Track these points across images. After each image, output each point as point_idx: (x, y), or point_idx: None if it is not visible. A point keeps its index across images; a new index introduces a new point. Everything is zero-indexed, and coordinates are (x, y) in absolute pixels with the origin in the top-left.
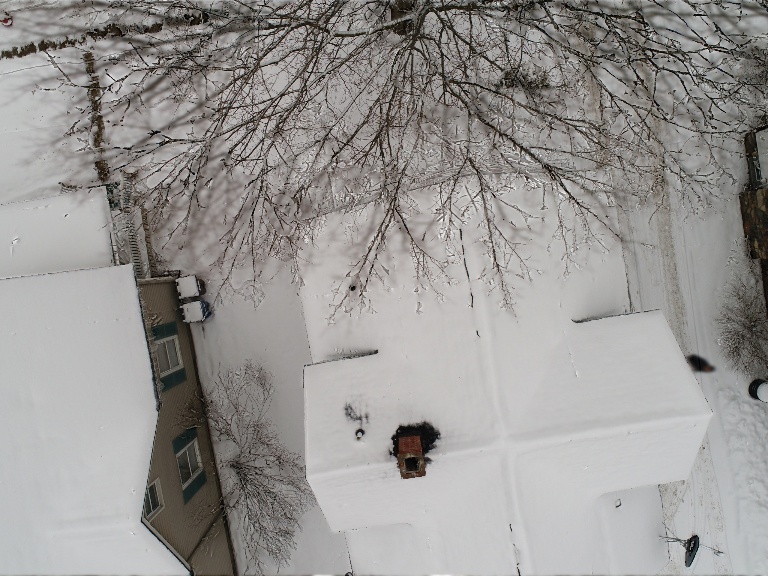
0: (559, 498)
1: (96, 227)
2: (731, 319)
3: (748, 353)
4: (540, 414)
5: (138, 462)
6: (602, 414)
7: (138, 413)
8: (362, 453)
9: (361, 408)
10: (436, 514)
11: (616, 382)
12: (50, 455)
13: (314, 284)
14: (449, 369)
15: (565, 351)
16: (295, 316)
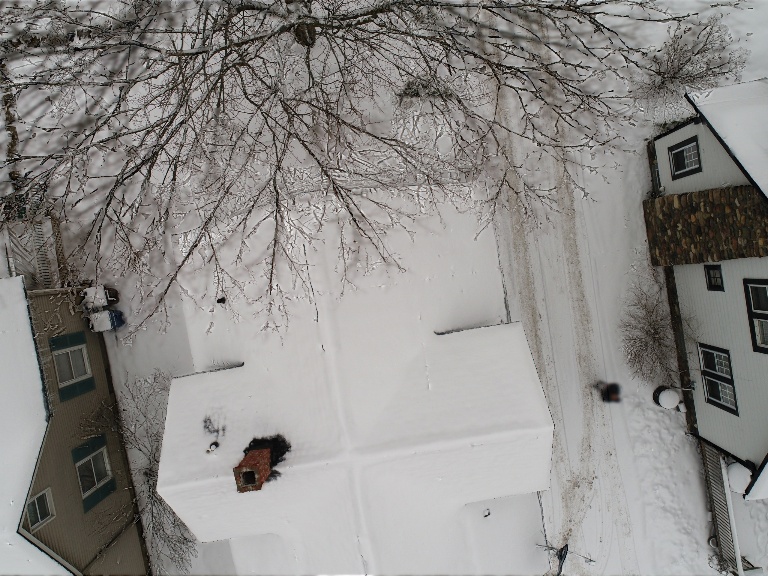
0: (414, 509)
1: None
2: (633, 326)
3: (651, 360)
4: (389, 427)
5: (20, 473)
6: (448, 427)
7: (25, 424)
8: (213, 466)
9: (219, 421)
10: (299, 525)
11: (466, 394)
12: None
13: None
14: (302, 382)
15: (422, 363)
16: None
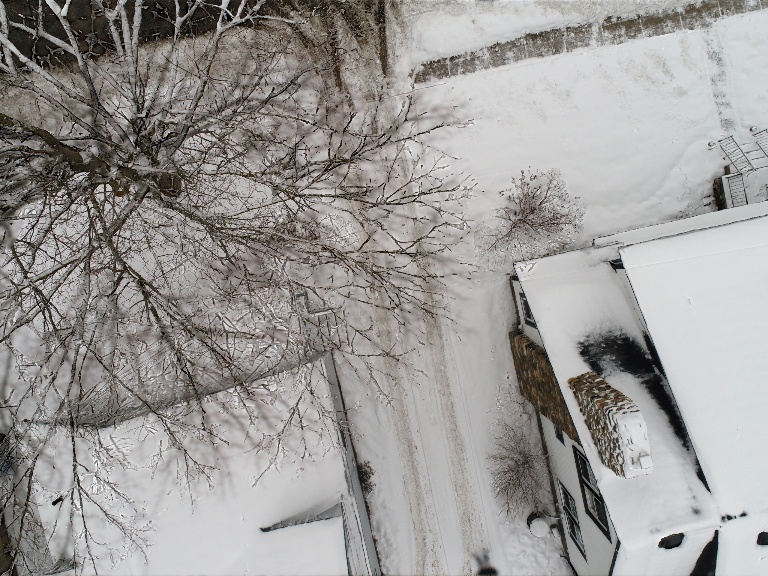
0: None
1: None
2: (503, 458)
3: (521, 489)
4: None
5: None
6: None
7: None
8: None
9: None
10: None
11: None
12: None
13: None
14: None
15: (242, 567)
16: None
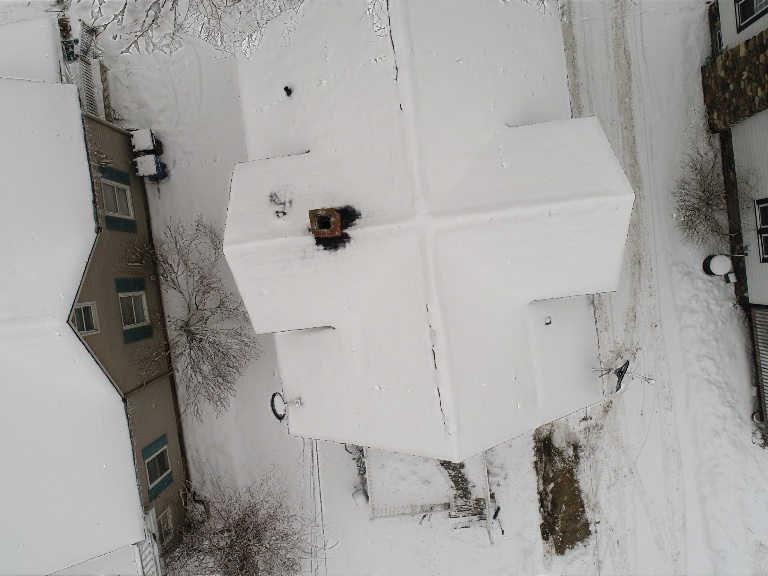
0: (481, 292)
1: (45, 53)
2: (687, 191)
3: (703, 226)
4: (463, 197)
5: (70, 272)
6: (524, 196)
7: (75, 231)
8: (281, 229)
9: (286, 195)
10: (359, 312)
11: (542, 171)
12: None
13: (254, 98)
14: (374, 152)
15: (495, 147)
16: None
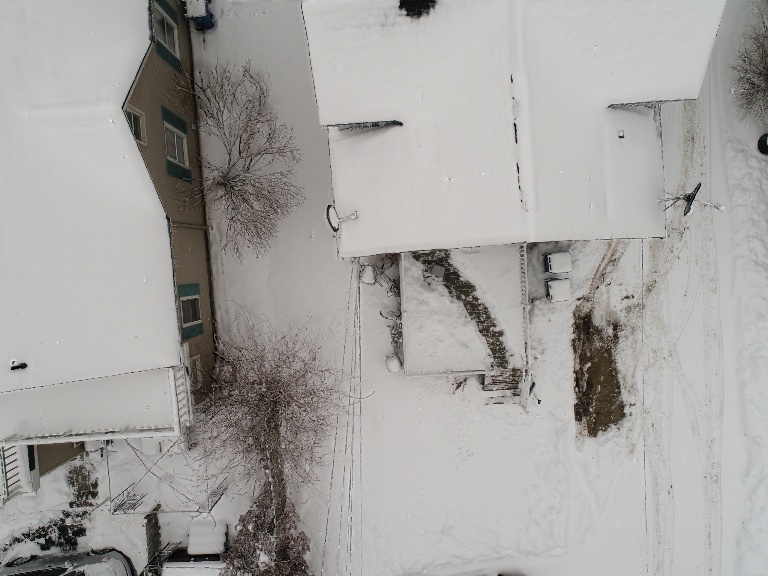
0: (564, 78)
1: None
2: None
3: None
4: None
5: (125, 67)
6: None
7: (130, 33)
8: None
9: None
10: (432, 101)
11: None
12: (34, 36)
13: None
14: None
15: None
16: (300, 33)
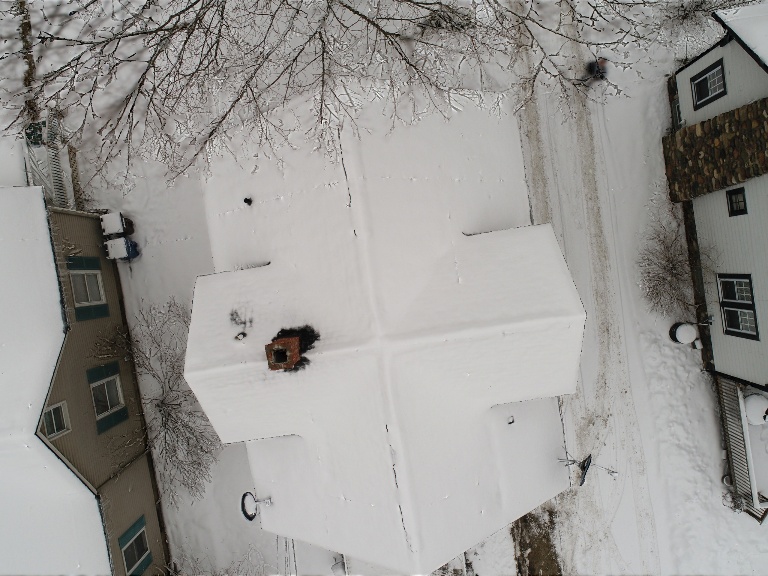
0: (441, 405)
1: (9, 152)
2: (651, 261)
3: (668, 295)
4: (419, 317)
5: (38, 379)
6: (479, 316)
7: (43, 334)
8: (241, 353)
9: (246, 313)
10: (323, 423)
11: (496, 287)
12: None
13: (216, 202)
14: (331, 273)
15: (451, 260)
16: None
